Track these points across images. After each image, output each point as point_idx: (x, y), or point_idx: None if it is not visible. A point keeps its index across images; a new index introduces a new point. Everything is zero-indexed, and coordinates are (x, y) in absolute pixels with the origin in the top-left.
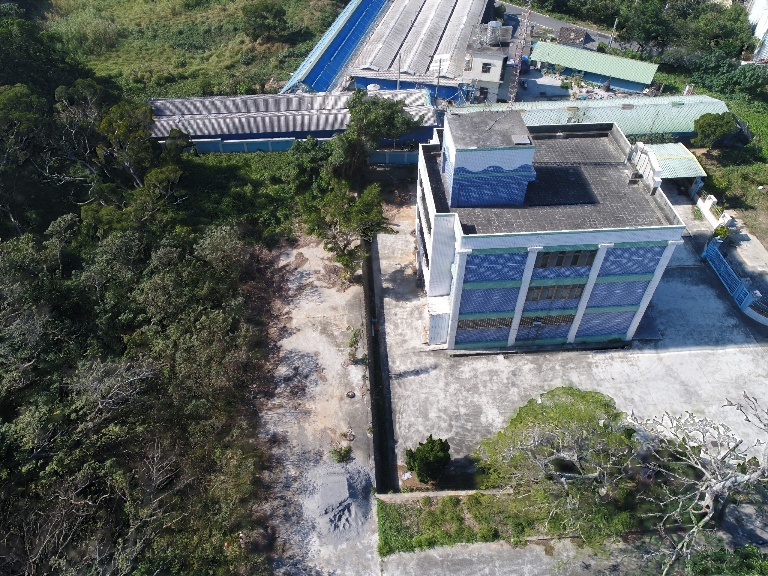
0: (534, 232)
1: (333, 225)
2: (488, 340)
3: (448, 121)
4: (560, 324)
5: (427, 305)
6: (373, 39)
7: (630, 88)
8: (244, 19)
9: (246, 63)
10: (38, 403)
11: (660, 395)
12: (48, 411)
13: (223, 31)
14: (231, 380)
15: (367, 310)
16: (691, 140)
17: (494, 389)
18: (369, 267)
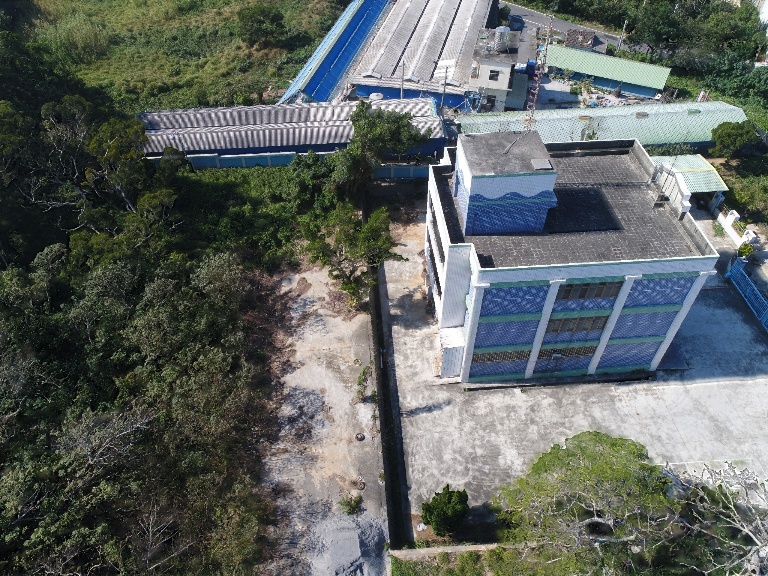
0: (557, 265)
1: (338, 251)
2: (504, 372)
3: (462, 143)
4: (581, 356)
5: (439, 335)
6: (374, 44)
7: (641, 93)
8: (240, 24)
9: (243, 70)
10: (23, 458)
11: (689, 432)
12: (34, 468)
13: (218, 36)
14: (232, 422)
15: (375, 340)
16: (709, 150)
17: (512, 427)
18: (376, 291)
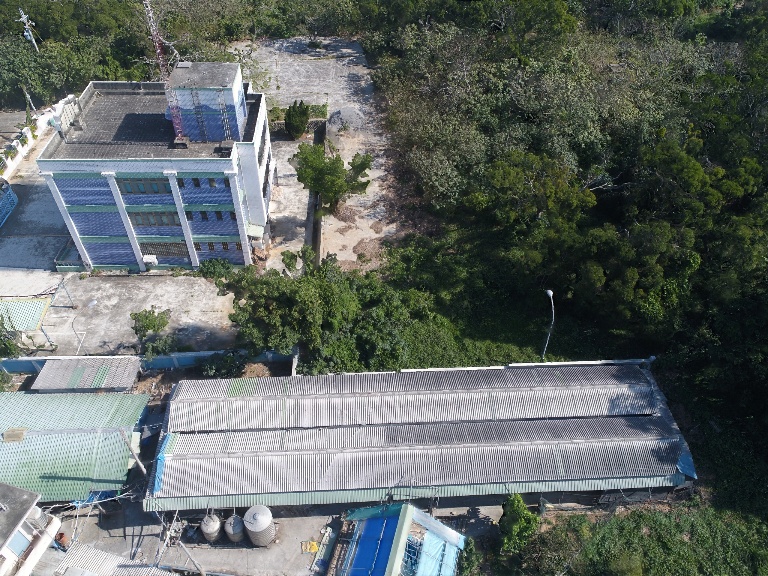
0: None
1: None
2: None
3: None
4: None
5: None
6: None
7: None
8: None
9: None
10: None
11: None
12: None
13: None
14: None
15: None
16: None
17: None
18: (315, 249)
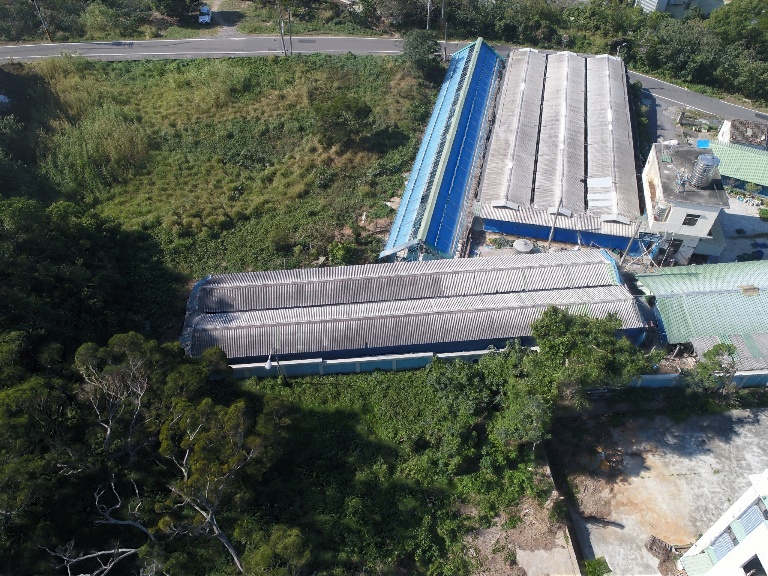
0: None
1: None
2: None
3: None
4: None
5: None
6: (495, 150)
7: None
8: (318, 124)
9: (323, 185)
10: None
11: None
12: None
13: (285, 131)
14: None
15: None
16: None
17: None
18: None
